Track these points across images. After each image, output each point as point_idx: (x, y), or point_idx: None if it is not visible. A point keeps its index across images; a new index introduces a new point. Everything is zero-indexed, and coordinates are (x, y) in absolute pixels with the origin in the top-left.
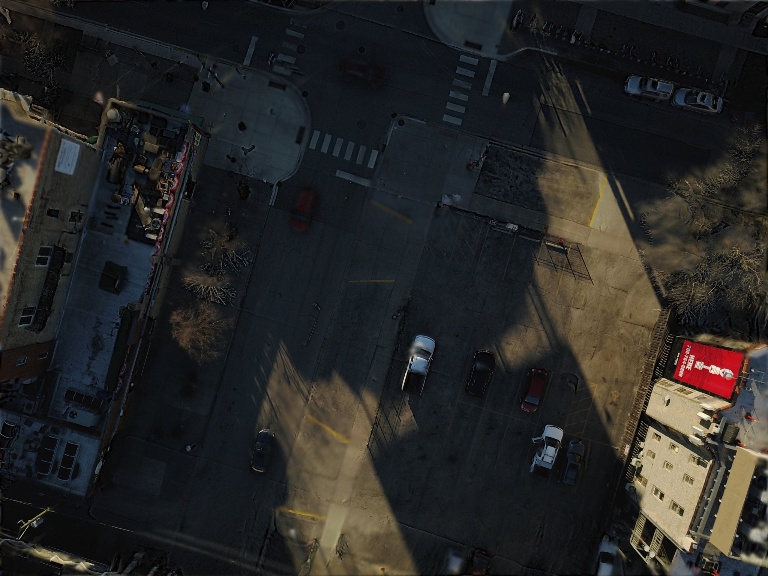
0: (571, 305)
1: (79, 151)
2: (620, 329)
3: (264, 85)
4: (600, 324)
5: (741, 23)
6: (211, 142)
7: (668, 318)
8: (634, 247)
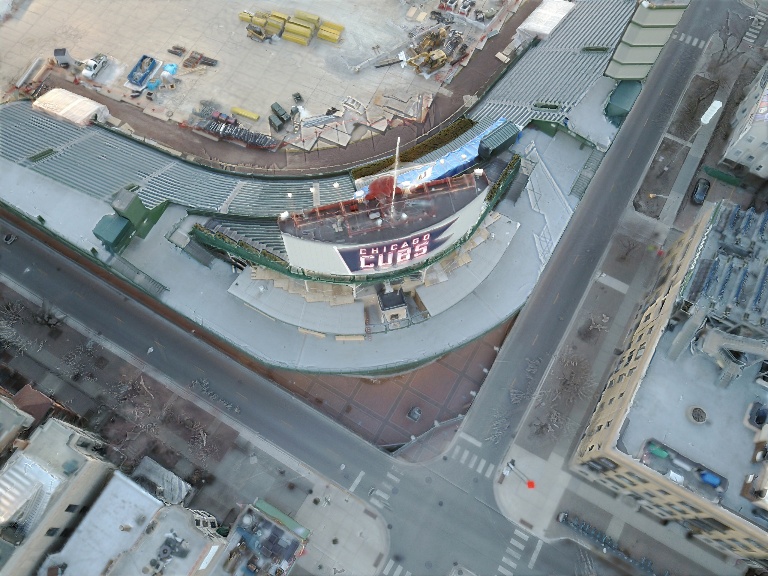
0: None
1: (217, 550)
2: None
3: (360, 511)
4: None
5: (736, 566)
6: (308, 547)
7: None
8: None
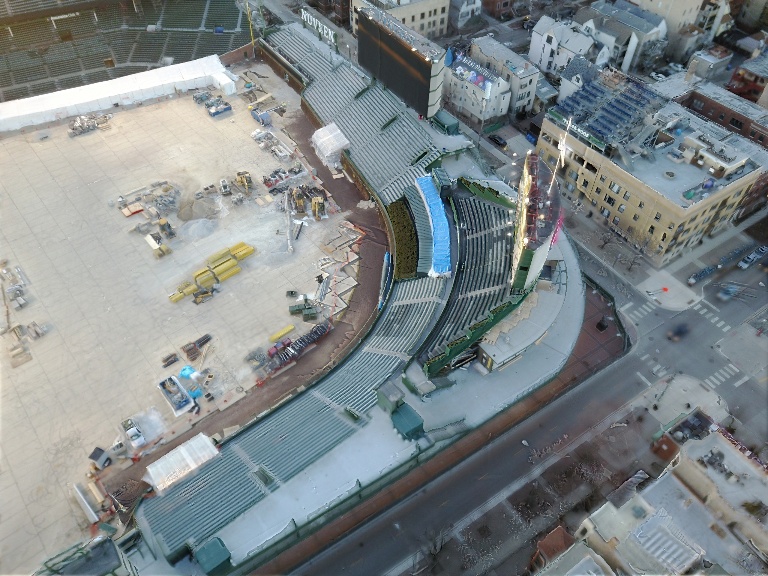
0: None
1: None
2: None
3: None
4: None
5: (729, 227)
6: None
7: None
8: None
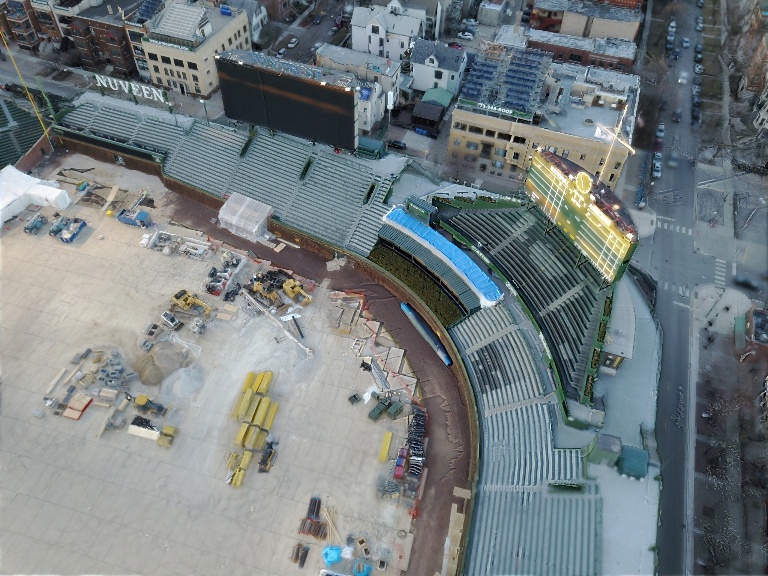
0: (763, 198)
1: None
2: (767, 185)
3: None
4: (767, 190)
5: None
6: None
7: (759, 167)
8: (727, 180)
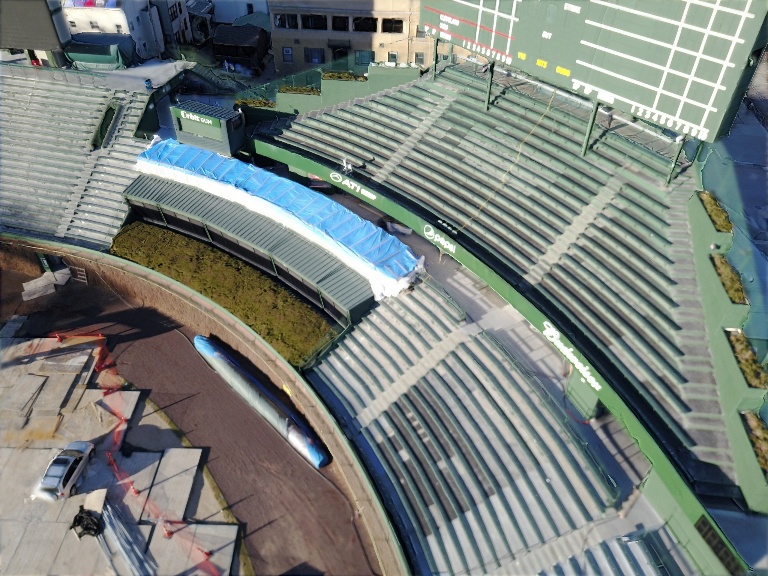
0: None
1: None
2: (767, 72)
3: None
4: None
5: None
6: None
7: None
8: None
